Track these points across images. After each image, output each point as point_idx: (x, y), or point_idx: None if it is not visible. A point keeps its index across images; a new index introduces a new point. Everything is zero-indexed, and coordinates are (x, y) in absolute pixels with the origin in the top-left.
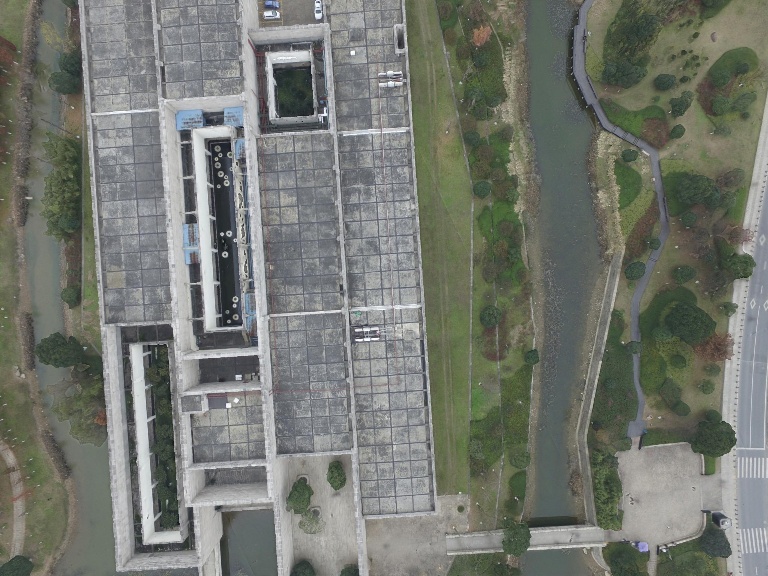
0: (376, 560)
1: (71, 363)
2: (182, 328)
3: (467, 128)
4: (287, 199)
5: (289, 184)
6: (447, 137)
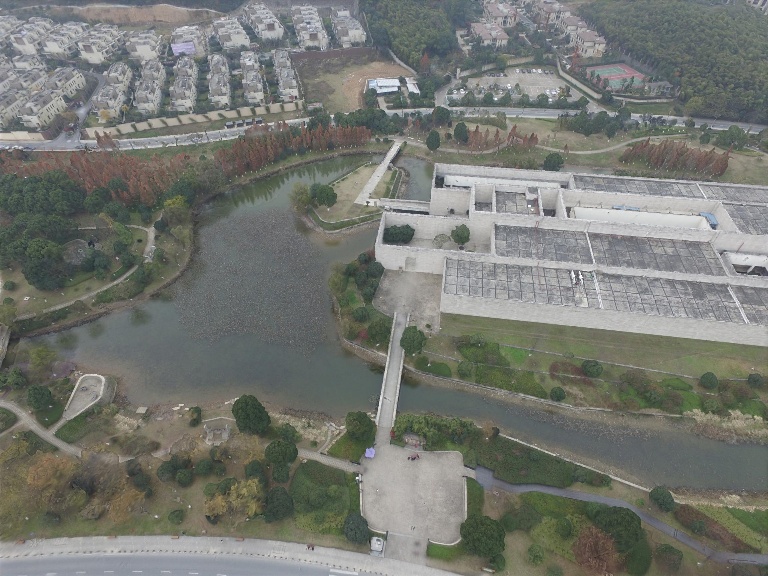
0: (400, 275)
1: (548, 164)
2: (577, 195)
3: (764, 378)
4: (670, 250)
5: (681, 253)
6: (748, 368)
